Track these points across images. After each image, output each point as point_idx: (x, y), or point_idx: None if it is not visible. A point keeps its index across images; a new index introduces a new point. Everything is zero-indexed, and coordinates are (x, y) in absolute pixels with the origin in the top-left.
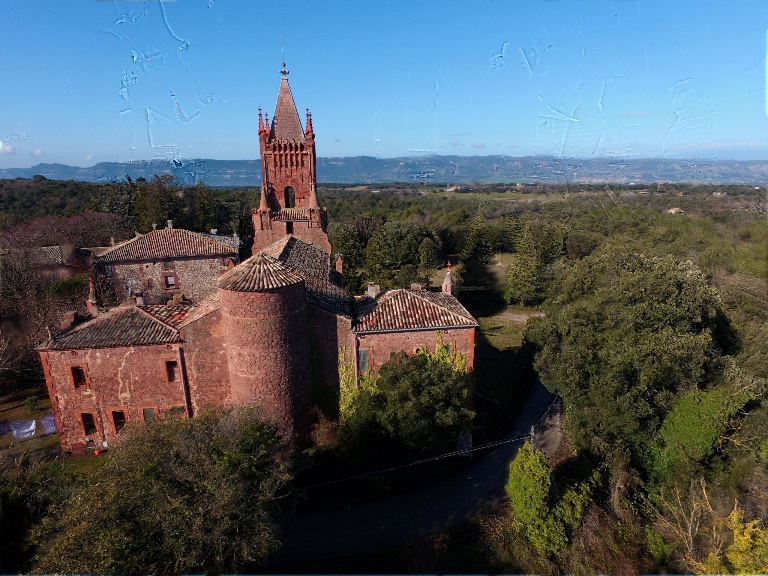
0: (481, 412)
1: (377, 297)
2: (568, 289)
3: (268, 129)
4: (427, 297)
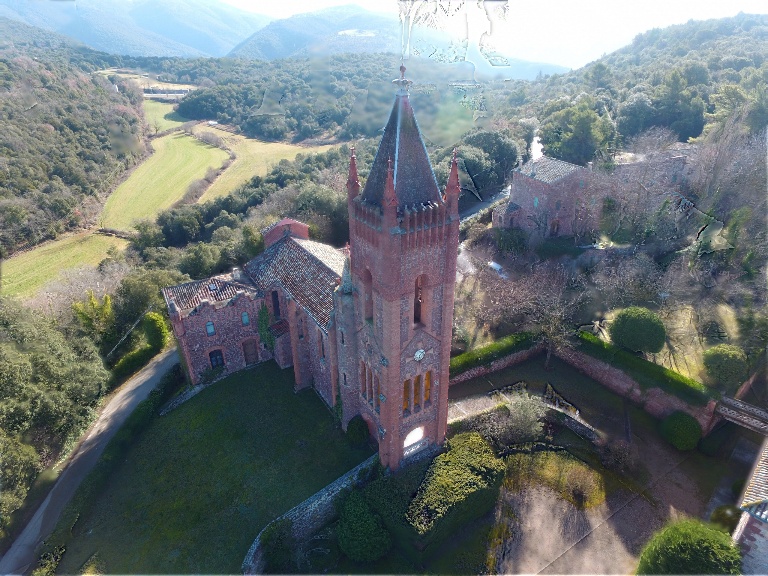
0: (168, 378)
1: (234, 281)
2: (30, 364)
3: (451, 177)
4: (195, 287)
